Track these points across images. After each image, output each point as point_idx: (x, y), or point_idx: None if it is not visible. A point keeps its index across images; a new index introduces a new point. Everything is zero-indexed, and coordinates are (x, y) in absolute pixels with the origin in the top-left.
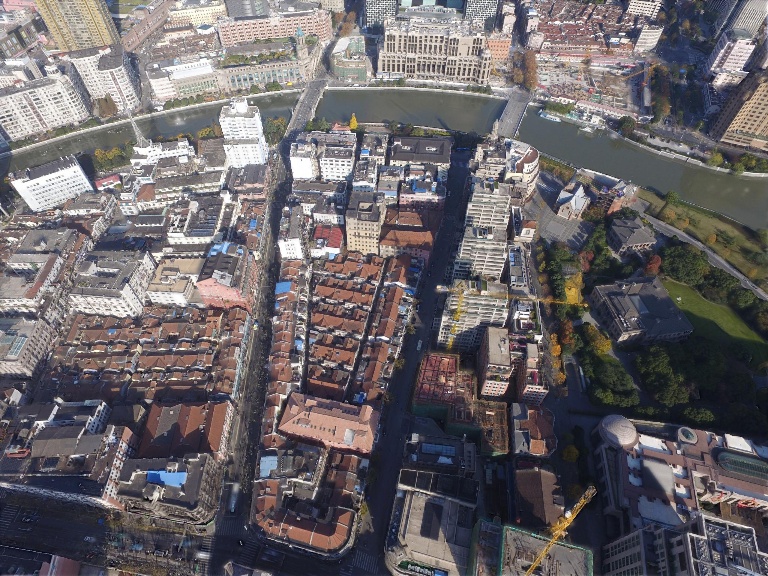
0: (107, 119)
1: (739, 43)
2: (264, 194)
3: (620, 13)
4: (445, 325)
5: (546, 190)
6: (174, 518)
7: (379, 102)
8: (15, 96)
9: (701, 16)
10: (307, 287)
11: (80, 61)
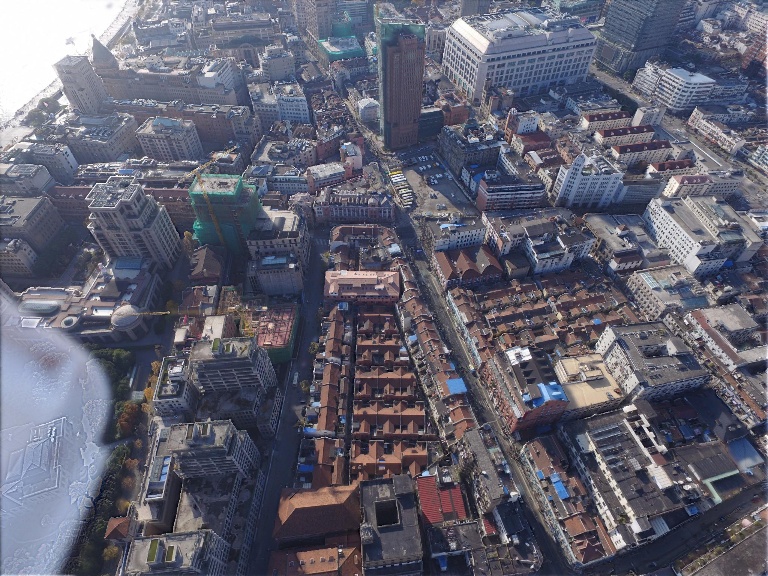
0: None
1: None
2: None
3: None
4: None
5: None
6: None
7: None
8: None
9: None
10: (436, 414)
11: None
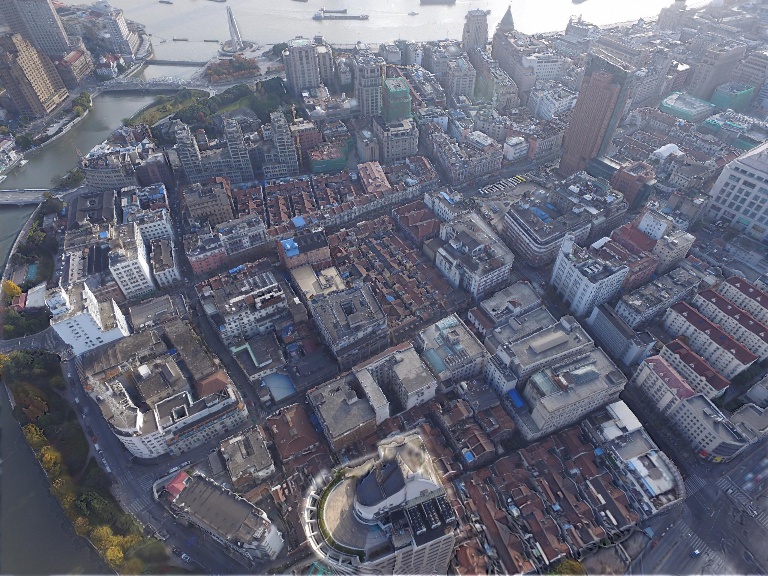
0: None
1: None
2: None
3: None
4: None
5: None
6: None
7: None
8: None
9: None
10: None
11: None
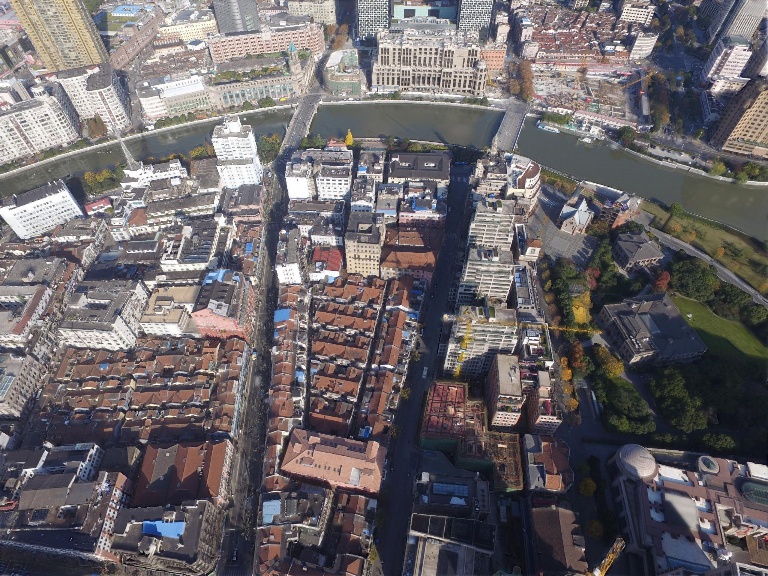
0: (96, 140)
1: (736, 50)
2: (260, 215)
3: (614, 20)
4: (452, 352)
5: (548, 204)
6: (172, 570)
7: (374, 116)
8: (1, 119)
9: (694, 22)
10: (307, 313)
11: (68, 81)
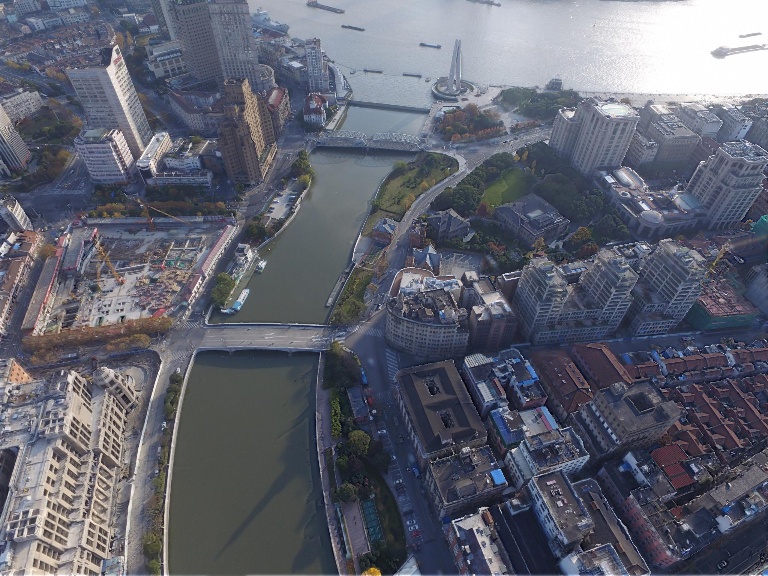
0: None
1: (115, 138)
2: None
3: None
4: None
5: None
6: None
7: None
8: None
9: None
10: None
11: None
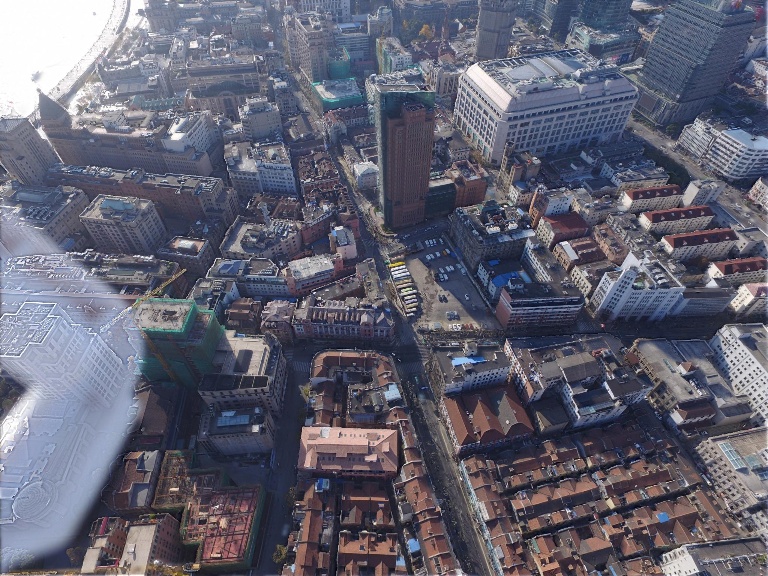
0: None
1: None
2: None
3: None
4: None
5: None
6: None
7: None
8: None
9: None
10: None
11: None
